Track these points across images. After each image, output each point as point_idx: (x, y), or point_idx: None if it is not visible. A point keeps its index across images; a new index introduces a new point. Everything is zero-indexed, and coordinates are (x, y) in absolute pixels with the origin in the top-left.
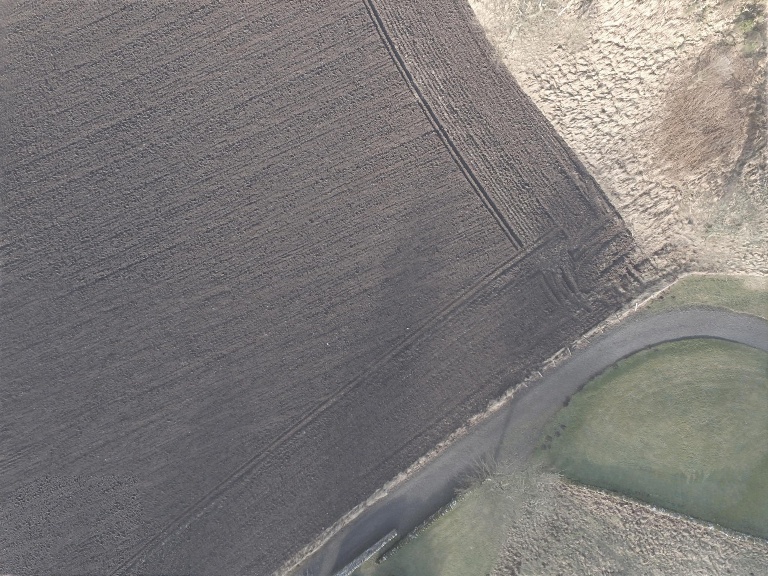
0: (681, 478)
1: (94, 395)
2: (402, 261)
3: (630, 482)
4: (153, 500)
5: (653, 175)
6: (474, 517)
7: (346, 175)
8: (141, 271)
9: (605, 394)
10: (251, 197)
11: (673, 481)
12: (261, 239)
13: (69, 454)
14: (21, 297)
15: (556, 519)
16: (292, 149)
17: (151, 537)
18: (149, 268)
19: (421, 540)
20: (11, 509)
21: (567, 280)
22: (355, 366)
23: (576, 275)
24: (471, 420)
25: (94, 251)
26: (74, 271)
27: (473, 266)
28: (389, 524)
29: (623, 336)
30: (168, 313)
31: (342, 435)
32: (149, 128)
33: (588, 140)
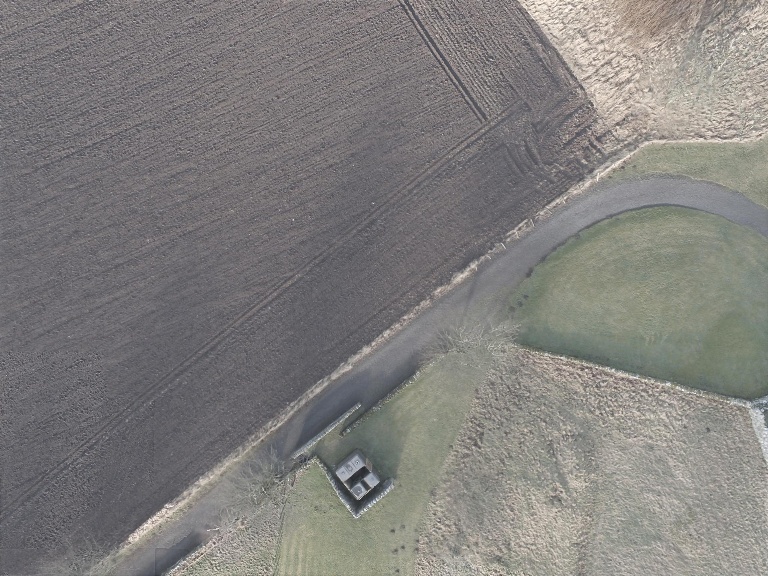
0: (640, 341)
1: (58, 272)
2: (368, 136)
3: (591, 347)
4: (117, 377)
5: (614, 44)
6: (437, 389)
7: (312, 51)
8: (107, 149)
9: (567, 263)
10: (218, 74)
11: (632, 344)
12: (227, 115)
13: (32, 330)
14: None
15: (518, 388)
16: (259, 25)
17: (115, 414)
18: (115, 145)
19: (385, 412)
20: None
21: (530, 153)
22: (320, 241)
23: (539, 147)
24: (435, 293)
25: (59, 129)
26: (39, 149)
27: (438, 140)
28: (353, 398)
29: (585, 206)
30: (134, 190)
31: (307, 310)
32: (116, 6)
33: (551, 10)
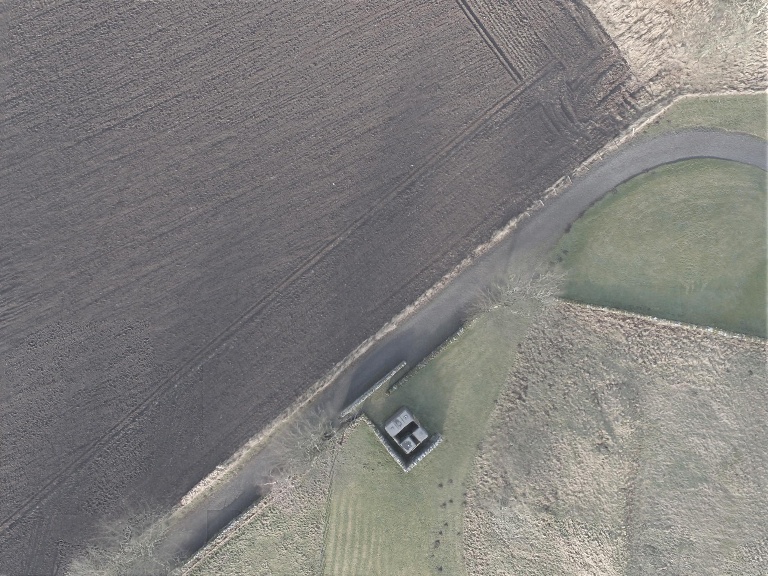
0: (680, 289)
1: (104, 242)
2: (405, 99)
3: (631, 298)
4: (165, 343)
5: (647, 1)
6: (481, 345)
7: (348, 17)
8: (147, 120)
9: (605, 217)
10: (255, 43)
11: (673, 293)
12: (266, 84)
13: (80, 300)
14: (28, 148)
15: (561, 341)
16: None
17: (164, 380)
18: (155, 117)
19: (430, 370)
20: (23, 355)
21: (566, 111)
22: (361, 204)
23: (574, 105)
24: (476, 251)
25: (100, 102)
26: (81, 122)
27: (474, 101)
28: (398, 357)
29: (621, 162)
30: (175, 160)
31: (350, 272)
32: None
33: None
